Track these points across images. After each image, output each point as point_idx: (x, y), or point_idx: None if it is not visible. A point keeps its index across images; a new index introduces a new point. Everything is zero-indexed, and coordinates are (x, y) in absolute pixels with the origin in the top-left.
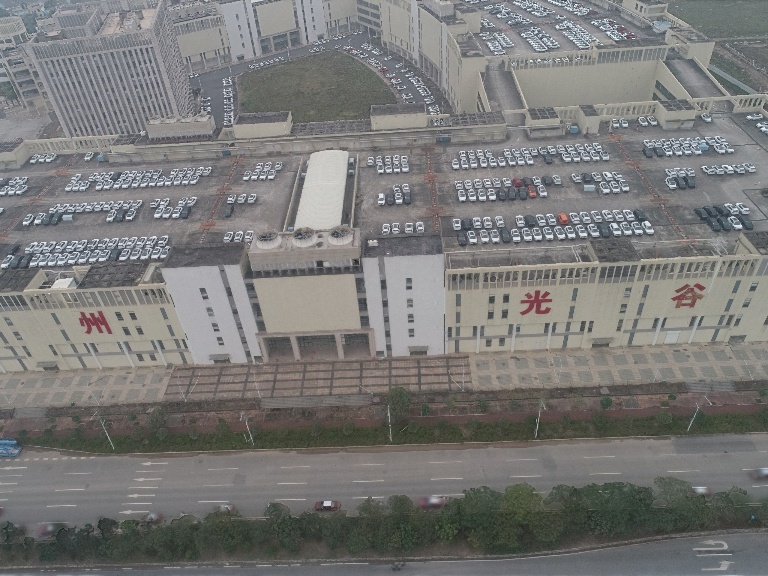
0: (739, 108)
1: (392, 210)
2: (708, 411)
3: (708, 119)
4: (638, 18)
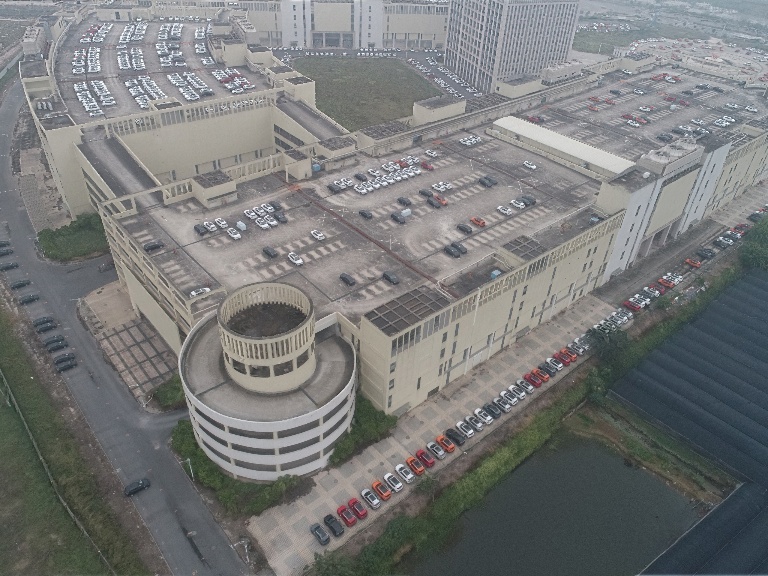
0: None
1: None
2: None
3: None
4: None
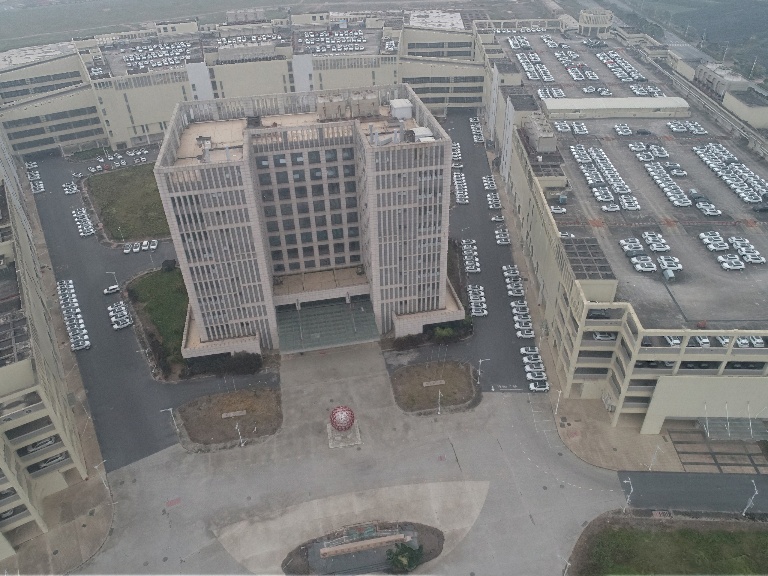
0: None
1: None
2: None
3: None
4: (324, 24)
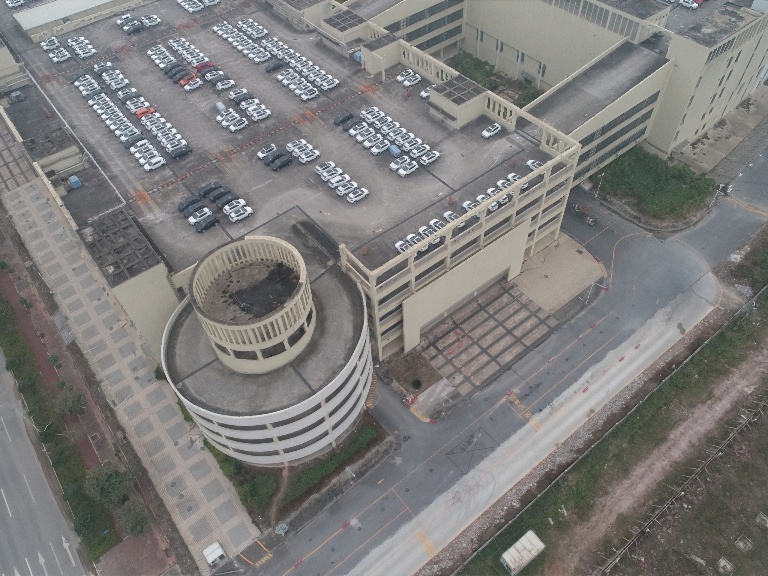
0: (547, 145)
1: (114, 32)
2: (31, 335)
3: (485, 132)
4: None
